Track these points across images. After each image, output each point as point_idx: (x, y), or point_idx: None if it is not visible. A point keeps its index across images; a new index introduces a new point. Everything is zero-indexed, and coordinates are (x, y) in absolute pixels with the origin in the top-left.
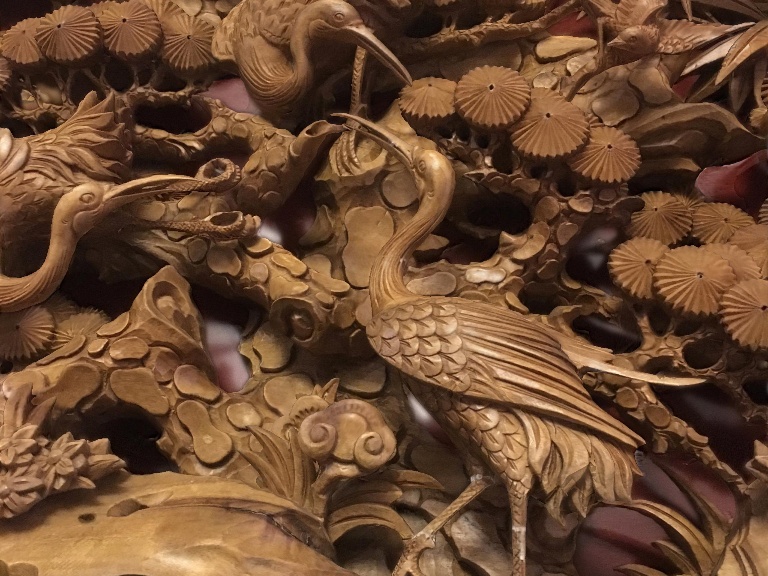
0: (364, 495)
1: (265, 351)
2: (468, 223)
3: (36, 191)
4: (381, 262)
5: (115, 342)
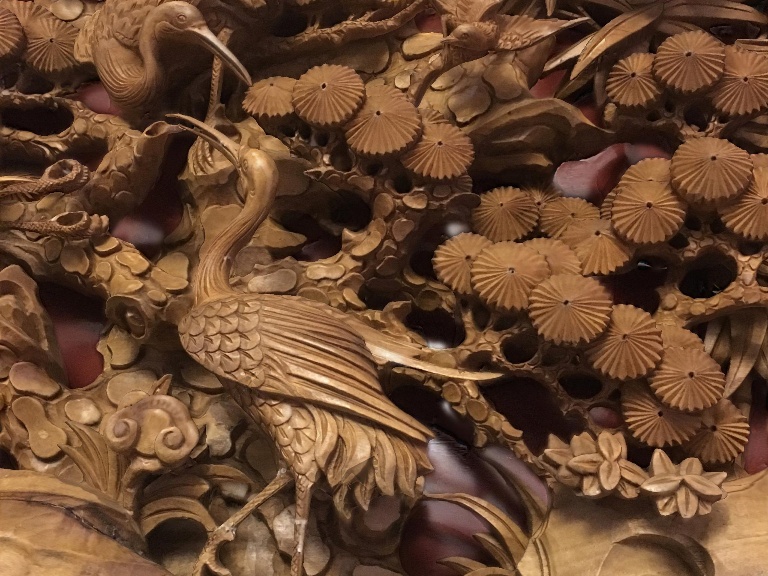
0: (174, 489)
1: (116, 348)
2: (328, 220)
3: None
4: (205, 260)
5: None
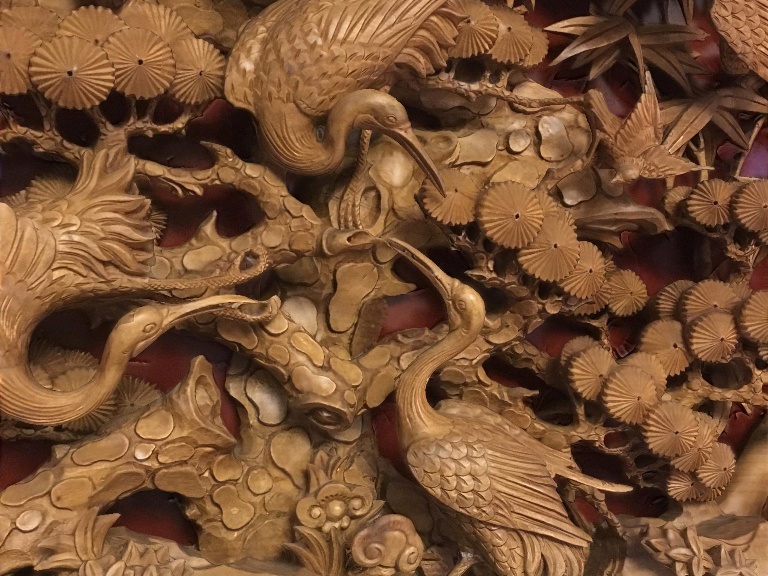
0: None
1: (261, 402)
2: None
3: (65, 289)
4: (413, 383)
5: (164, 449)
